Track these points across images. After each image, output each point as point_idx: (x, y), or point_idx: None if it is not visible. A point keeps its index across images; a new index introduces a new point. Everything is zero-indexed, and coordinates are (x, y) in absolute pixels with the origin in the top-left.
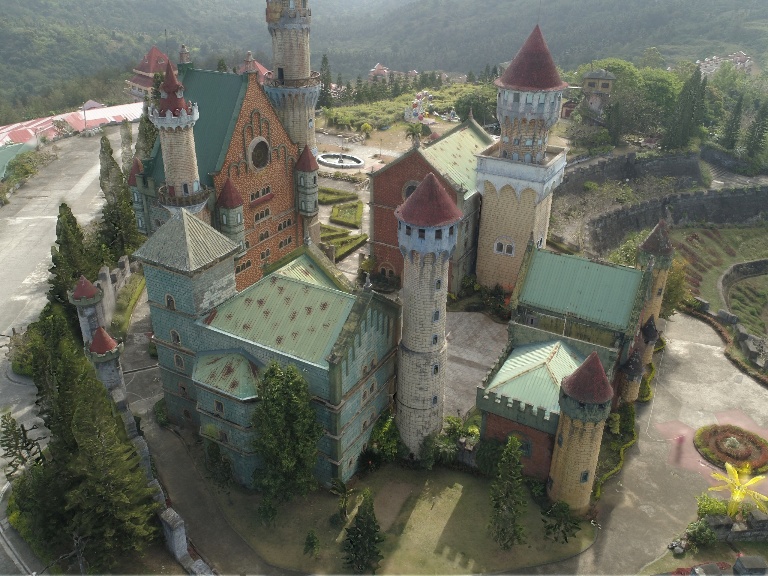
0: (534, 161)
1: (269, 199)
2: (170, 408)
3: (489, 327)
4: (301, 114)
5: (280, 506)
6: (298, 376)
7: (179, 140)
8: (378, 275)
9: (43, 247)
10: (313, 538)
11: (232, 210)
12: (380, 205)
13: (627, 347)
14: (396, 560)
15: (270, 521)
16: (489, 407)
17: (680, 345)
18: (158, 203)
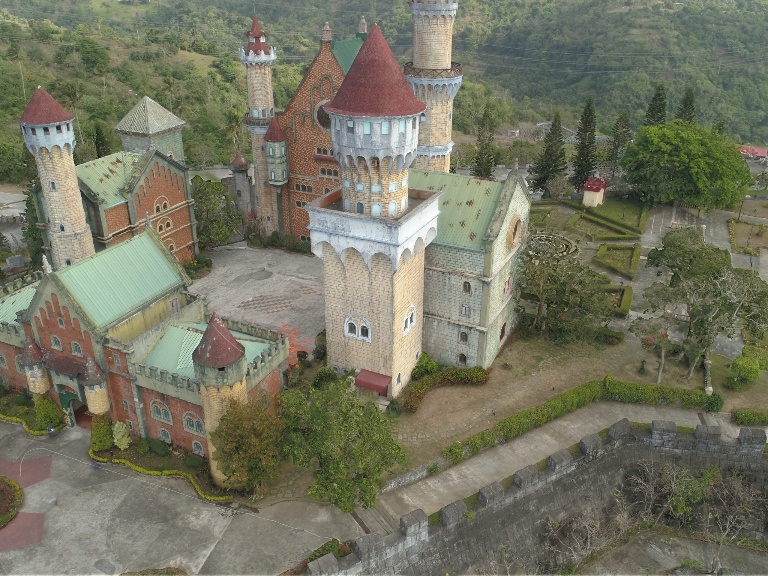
0: None
1: None
2: None
3: None
4: None
5: None
6: None
7: None
8: None
9: None
10: None
11: None
12: None
13: None
14: None
15: None
16: None
17: (213, 522)
18: None
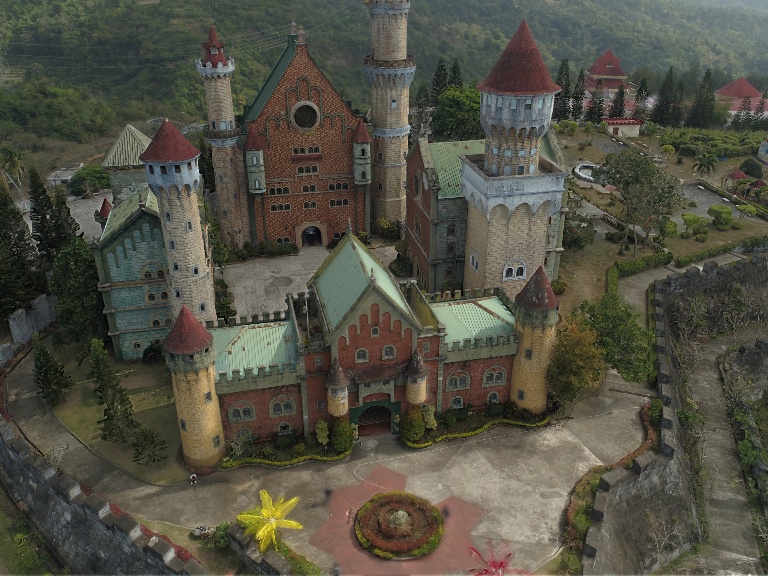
0: (501, 173)
1: (318, 158)
2: None
3: None
4: (383, 93)
5: None
6: (81, 250)
7: (210, 86)
8: (404, 258)
9: None
10: None
11: (248, 152)
12: (408, 190)
13: (331, 354)
14: (77, 410)
15: (58, 347)
16: None
17: (561, 437)
18: None
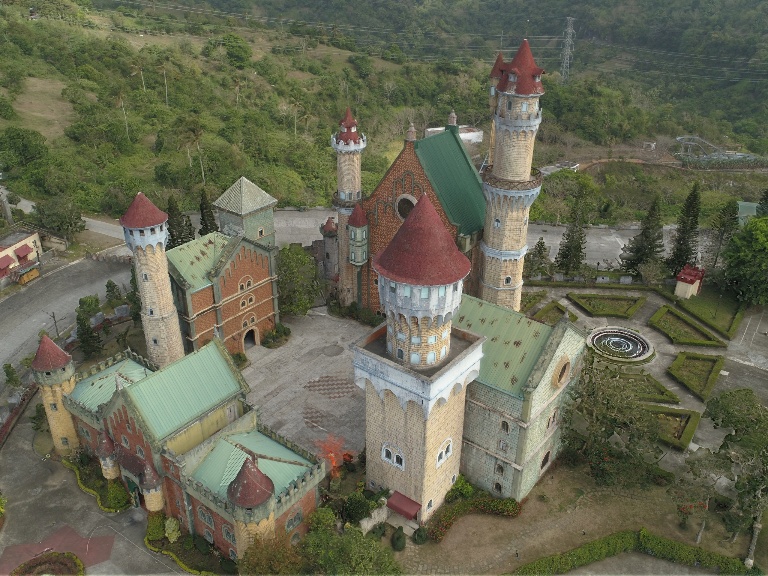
0: None
1: None
2: None
3: (329, 459)
4: None
5: None
6: None
7: None
8: None
9: (552, 252)
10: (105, 327)
11: None
12: None
13: None
14: None
15: None
16: None
17: None
18: None
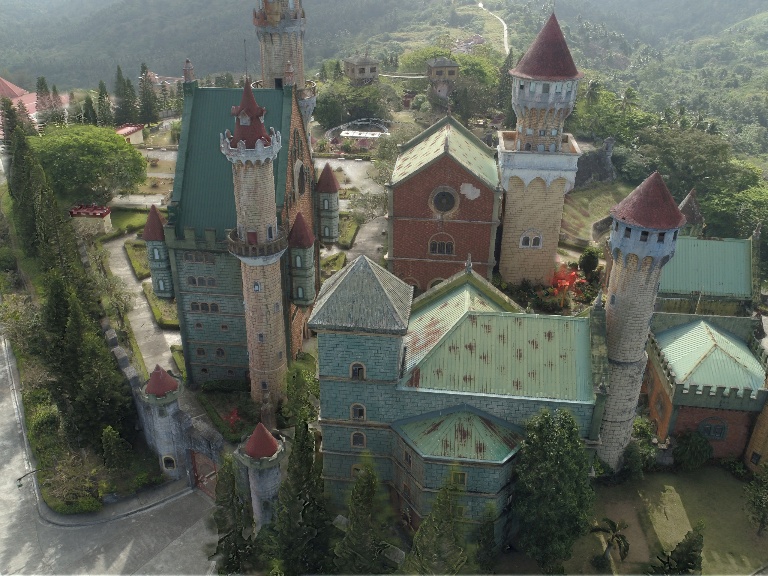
0: (557, 150)
1: None
2: (331, 498)
3: None
4: None
5: (533, 568)
6: (573, 419)
7: (265, 175)
8: None
9: None
10: None
11: (309, 249)
12: (402, 218)
13: None
14: None
15: None
16: (688, 401)
17: None
18: (194, 256)
